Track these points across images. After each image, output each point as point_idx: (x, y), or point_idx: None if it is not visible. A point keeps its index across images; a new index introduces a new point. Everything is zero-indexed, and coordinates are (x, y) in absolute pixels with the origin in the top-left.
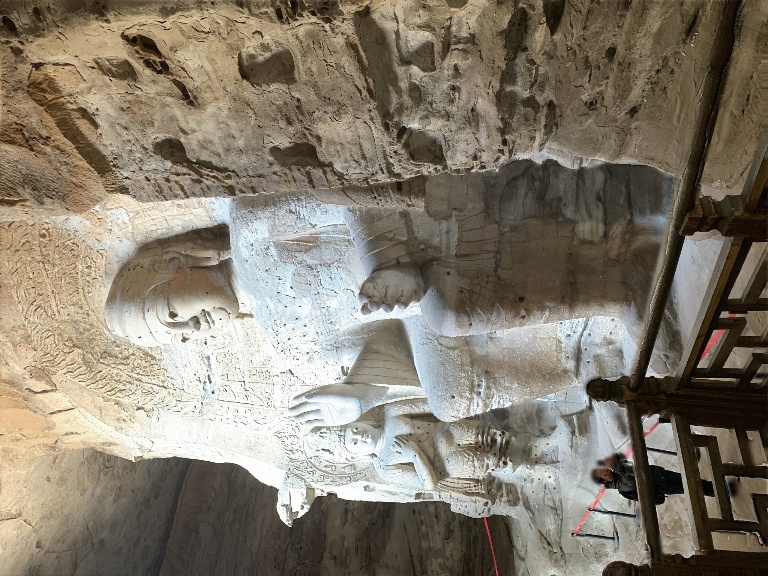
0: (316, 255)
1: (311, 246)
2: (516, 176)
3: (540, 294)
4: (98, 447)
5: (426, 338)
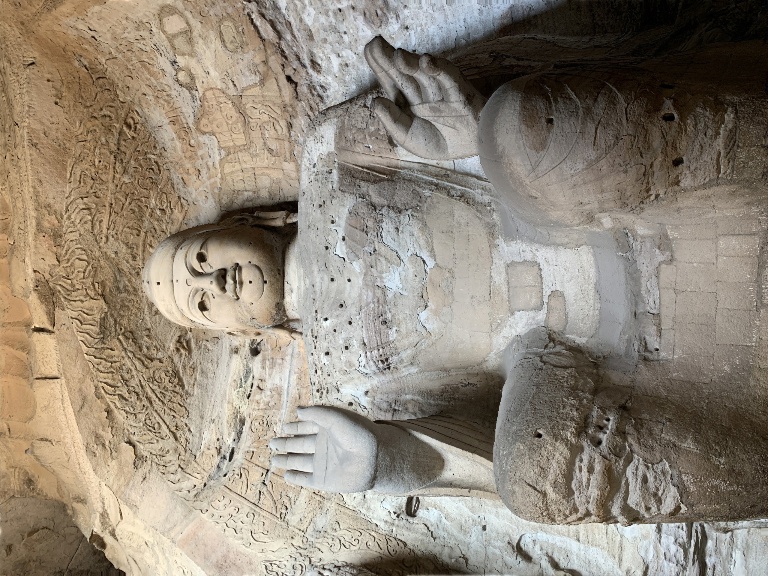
0: (386, 192)
1: (384, 178)
2: (693, 22)
3: (711, 83)
4: (71, 507)
5: (523, 358)
